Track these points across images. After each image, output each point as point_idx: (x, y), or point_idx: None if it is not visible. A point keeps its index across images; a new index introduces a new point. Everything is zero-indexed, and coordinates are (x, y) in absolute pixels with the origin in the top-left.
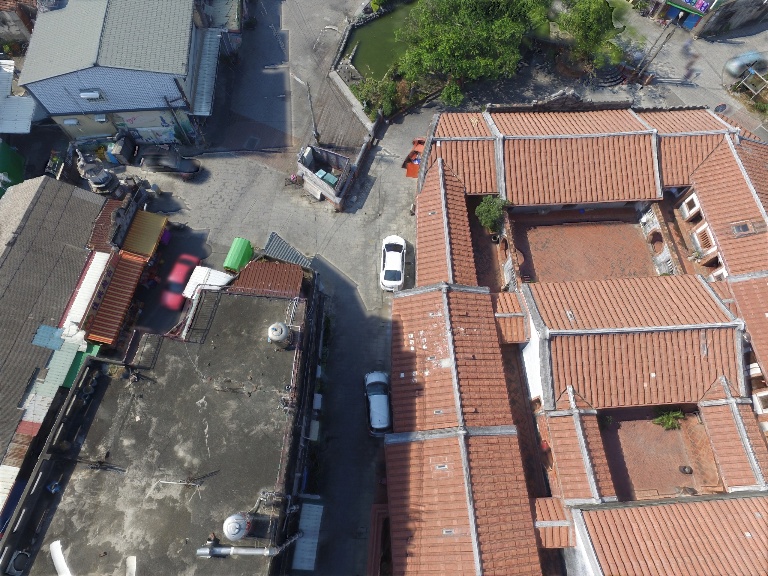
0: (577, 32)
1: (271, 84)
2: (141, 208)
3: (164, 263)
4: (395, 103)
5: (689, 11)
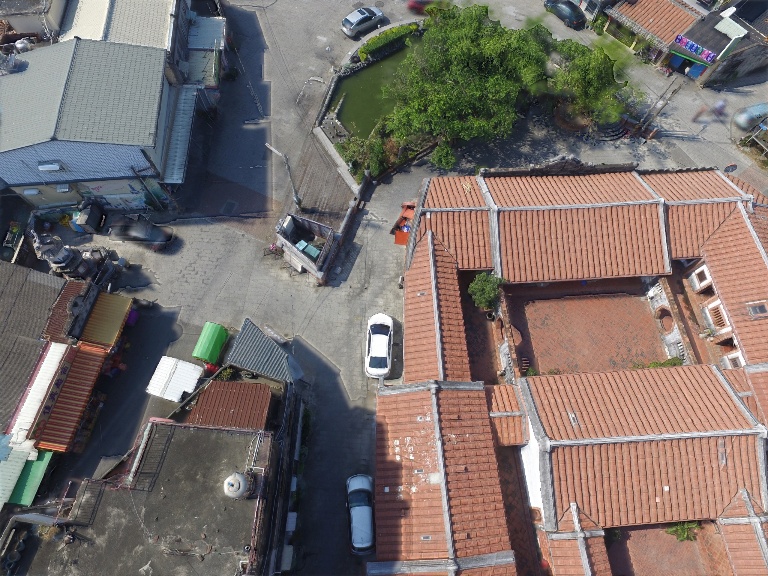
0: (576, 87)
1: (251, 141)
2: (107, 284)
3: (130, 347)
4: (383, 162)
5: (694, 61)
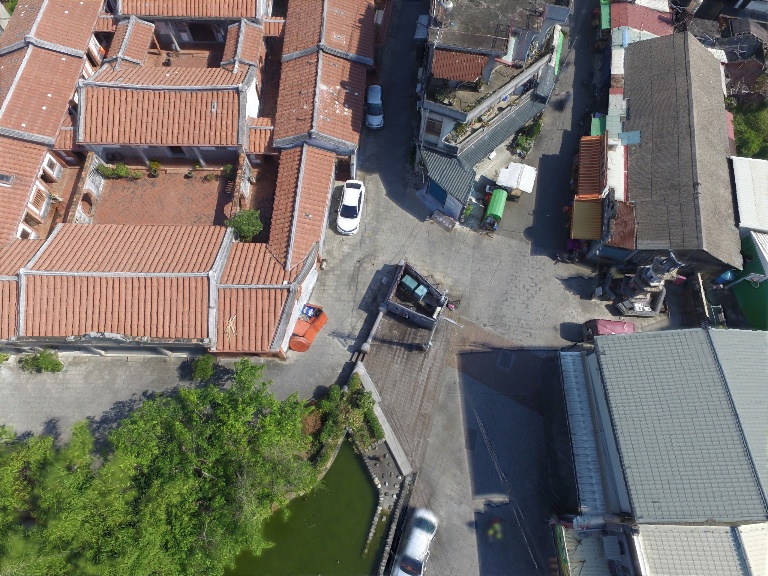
0: (16, 471)
1: None
2: None
3: (565, 225)
4: None
5: None
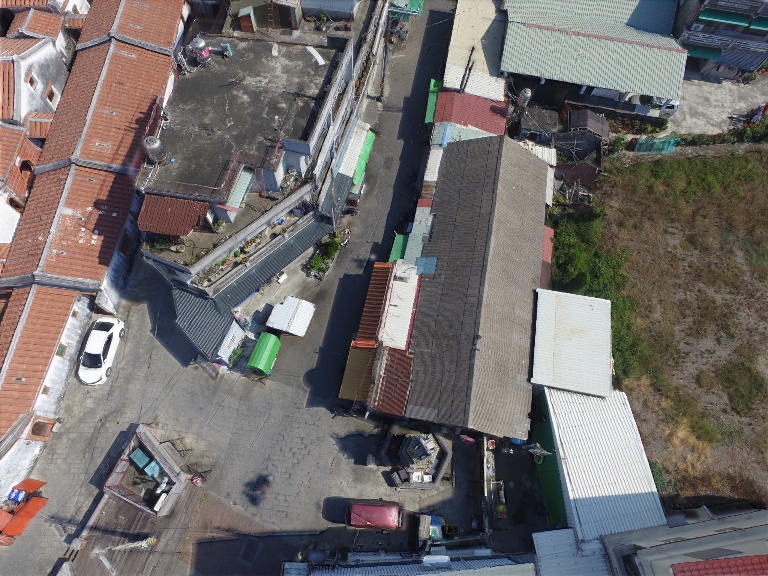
0: None
1: None
2: None
3: None
4: None
5: None
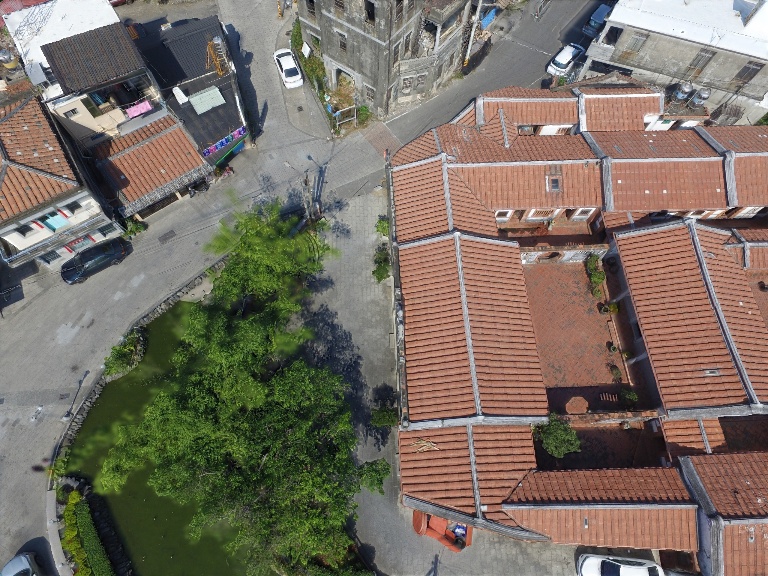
0: (280, 284)
1: None
2: None
3: None
4: None
5: None
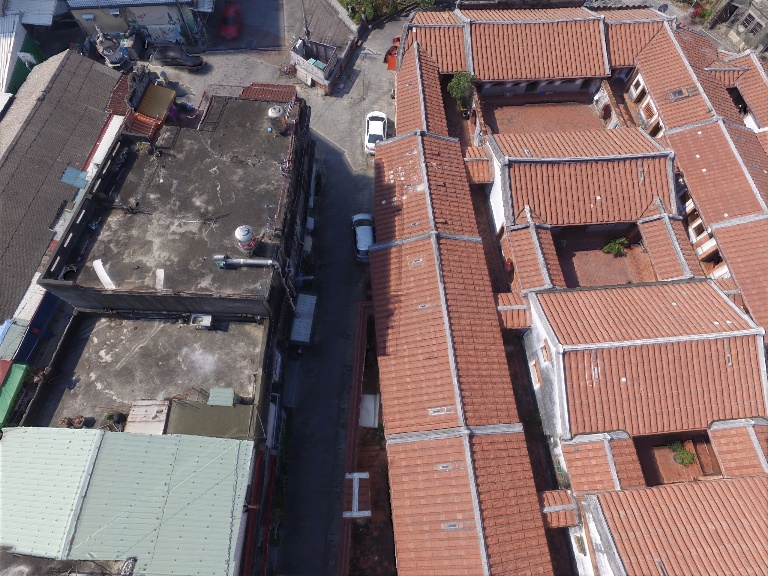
0: None
1: None
2: None
3: None
4: (377, 11)
5: None
